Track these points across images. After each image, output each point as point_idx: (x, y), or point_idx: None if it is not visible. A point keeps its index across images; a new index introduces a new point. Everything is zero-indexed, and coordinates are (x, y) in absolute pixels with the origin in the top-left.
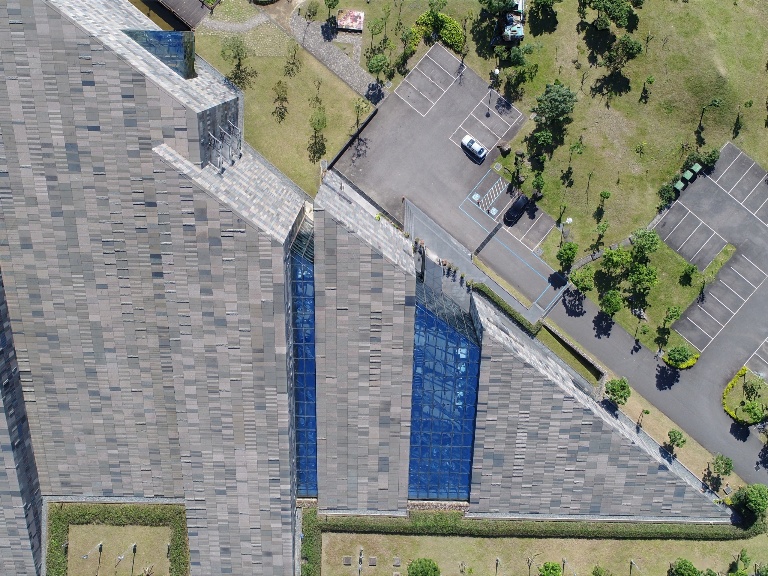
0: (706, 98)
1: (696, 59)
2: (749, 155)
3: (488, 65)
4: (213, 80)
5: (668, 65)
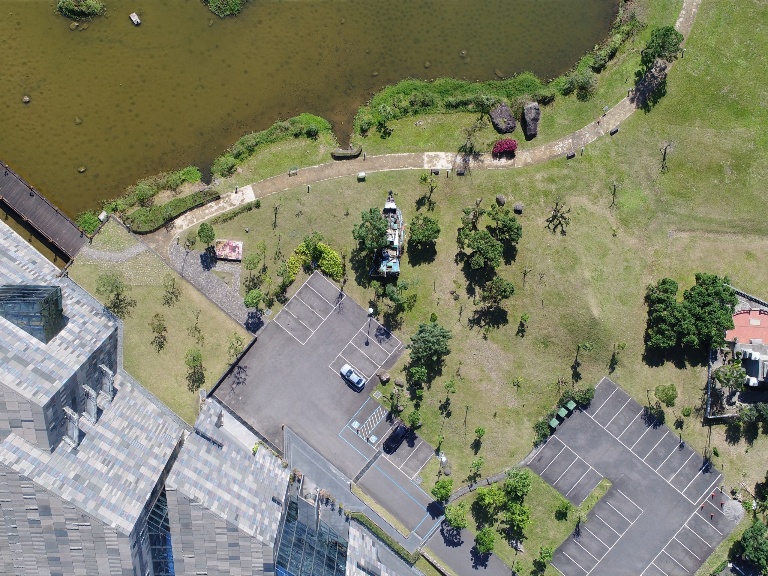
0: (581, 336)
1: (571, 297)
2: (625, 390)
3: (367, 294)
4: (89, 316)
5: (544, 300)
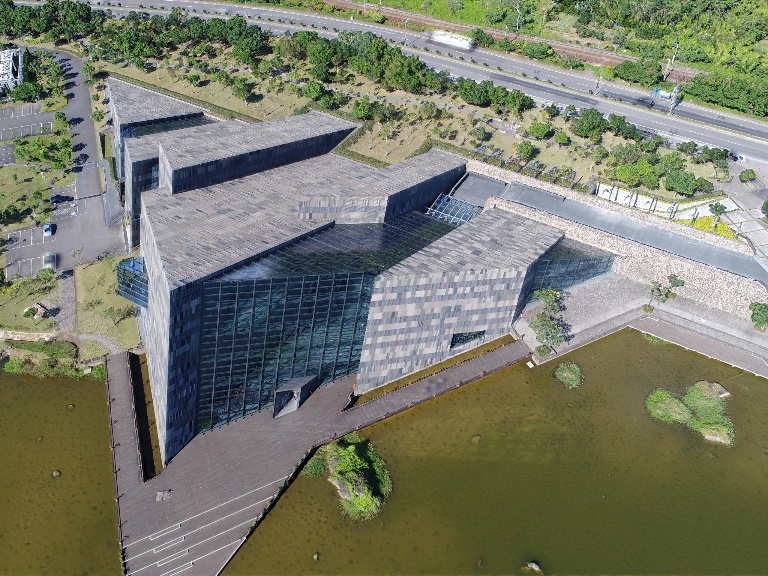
0: None
1: None
2: None
3: None
4: None
5: None
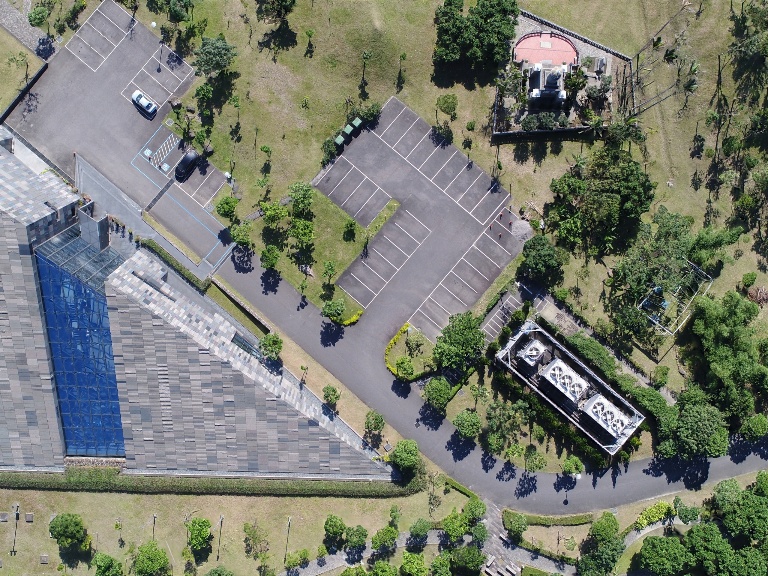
0: None
1: (356, 12)
2: (413, 110)
3: (159, 20)
4: None
5: (331, 19)
